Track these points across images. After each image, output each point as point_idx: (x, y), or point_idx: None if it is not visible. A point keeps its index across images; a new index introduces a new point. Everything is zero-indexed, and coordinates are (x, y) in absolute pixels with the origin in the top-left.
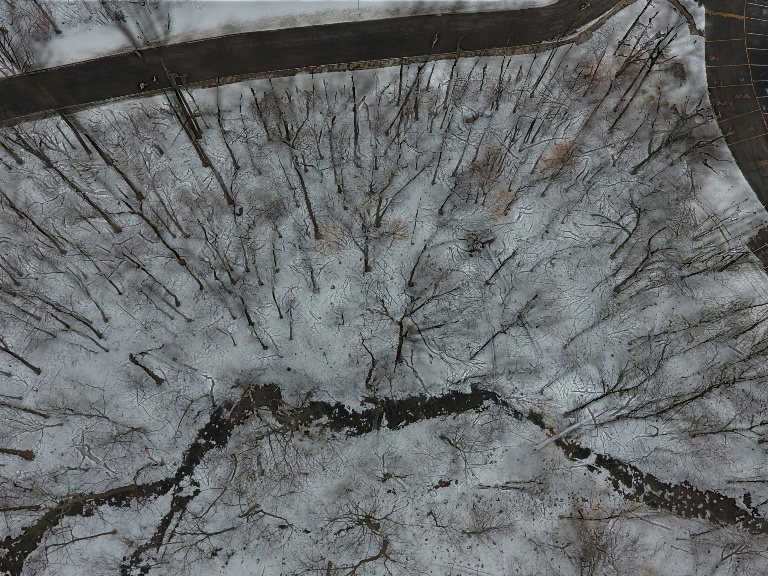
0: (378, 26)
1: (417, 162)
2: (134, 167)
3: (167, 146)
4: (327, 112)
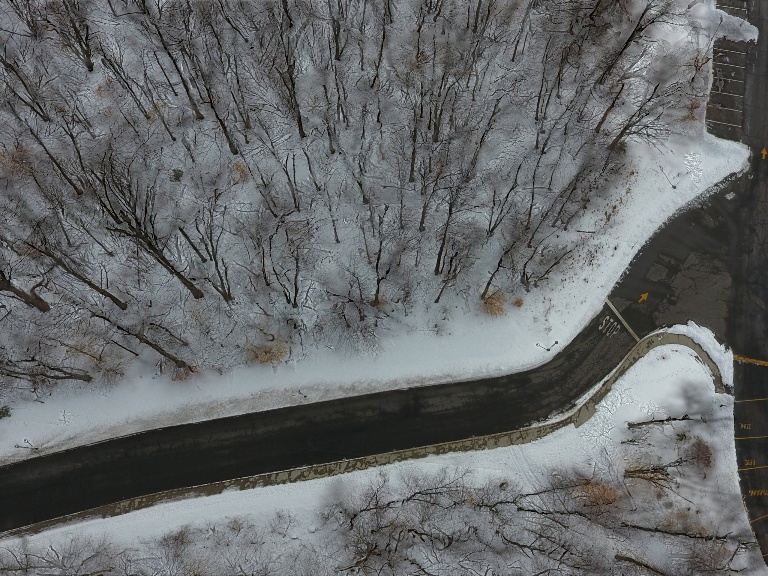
0: (328, 410)
1: None
2: None
3: None
4: (257, 569)
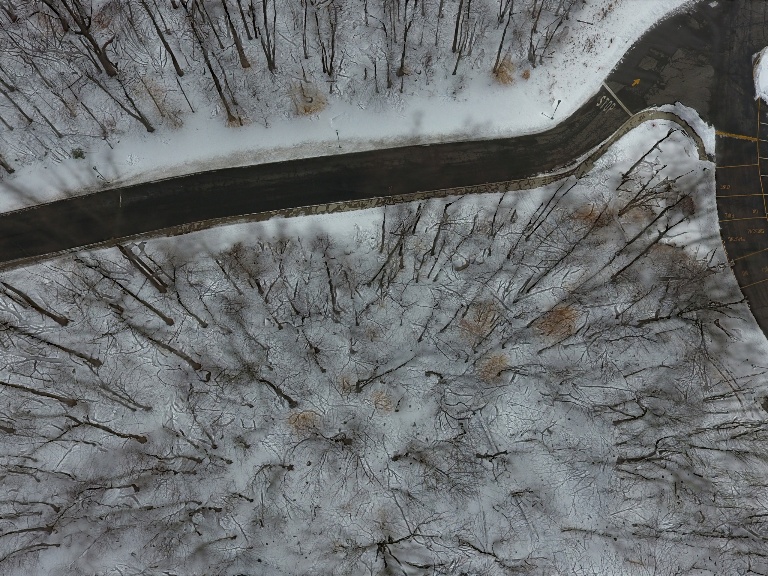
0: (360, 159)
1: (401, 320)
2: (91, 330)
3: (128, 302)
4: (302, 269)
